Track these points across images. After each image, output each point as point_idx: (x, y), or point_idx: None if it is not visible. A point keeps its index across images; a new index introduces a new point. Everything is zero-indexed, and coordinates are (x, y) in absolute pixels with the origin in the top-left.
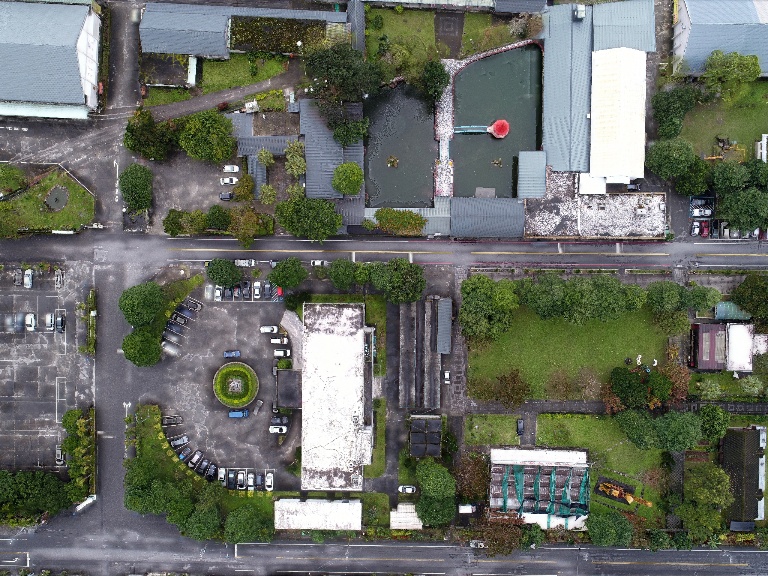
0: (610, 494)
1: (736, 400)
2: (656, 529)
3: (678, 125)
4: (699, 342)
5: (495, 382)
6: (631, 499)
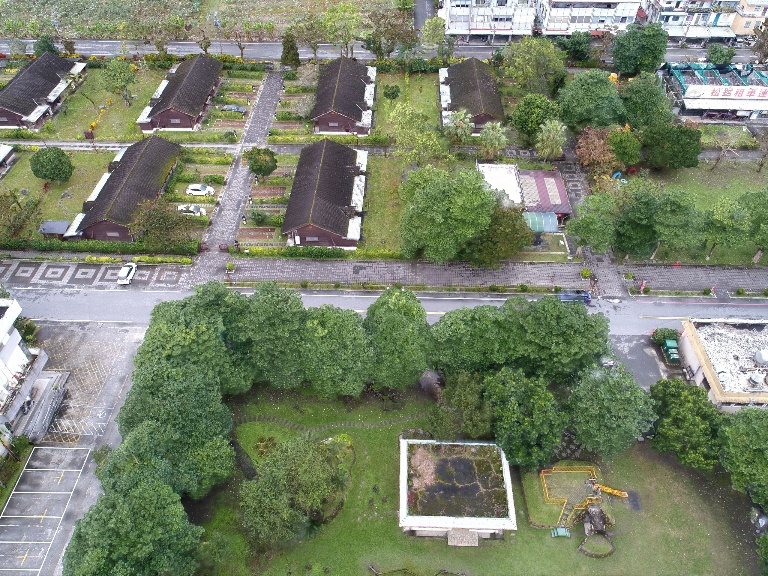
0: None
1: None
2: (584, 48)
3: None
4: None
5: None
6: (613, 75)
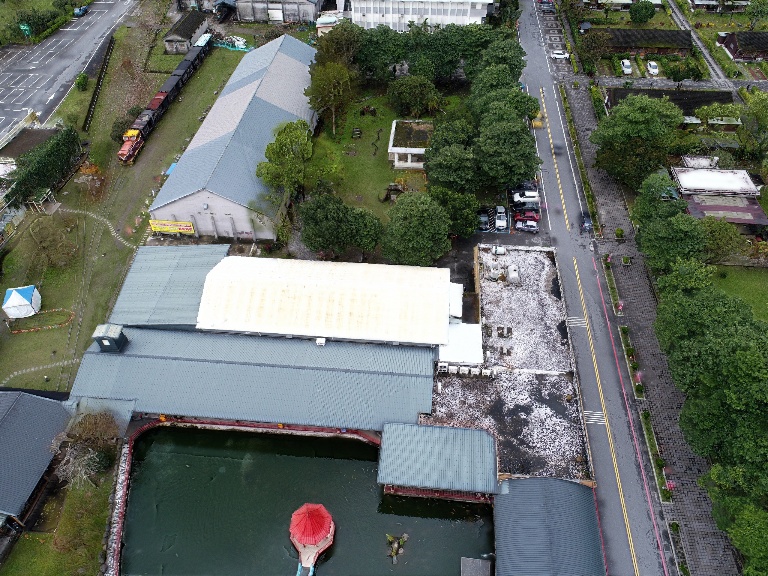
0: None
1: None
2: None
3: (366, 213)
4: None
5: None
6: None
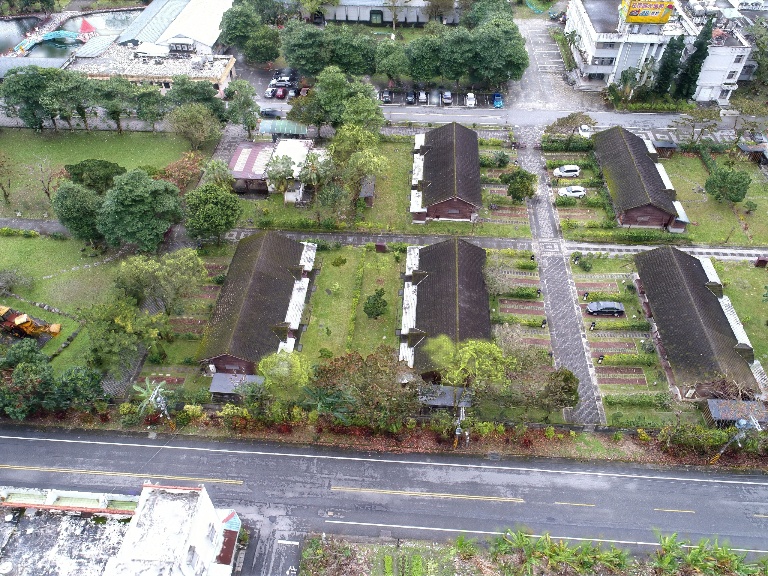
0: (6, 335)
1: (284, 226)
2: None
3: None
4: (234, 155)
5: None
6: (23, 317)
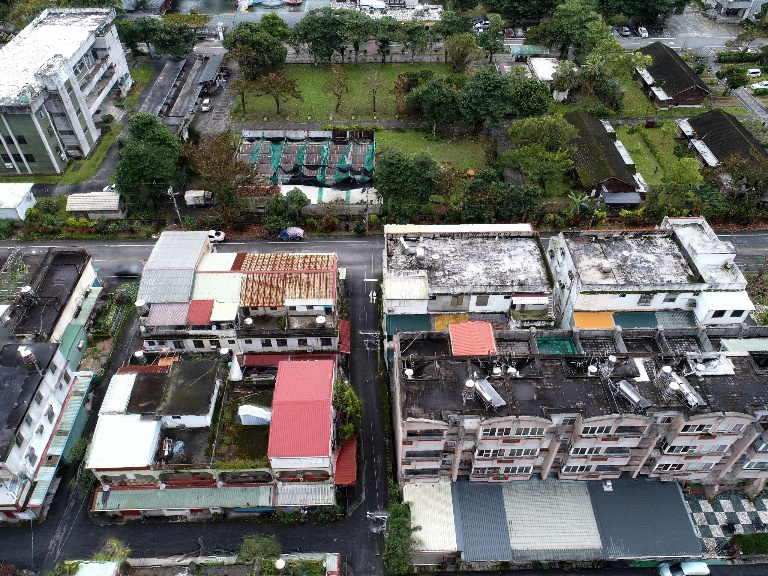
0: None
1: None
2: None
3: None
4: (500, 70)
5: (266, 110)
6: None
